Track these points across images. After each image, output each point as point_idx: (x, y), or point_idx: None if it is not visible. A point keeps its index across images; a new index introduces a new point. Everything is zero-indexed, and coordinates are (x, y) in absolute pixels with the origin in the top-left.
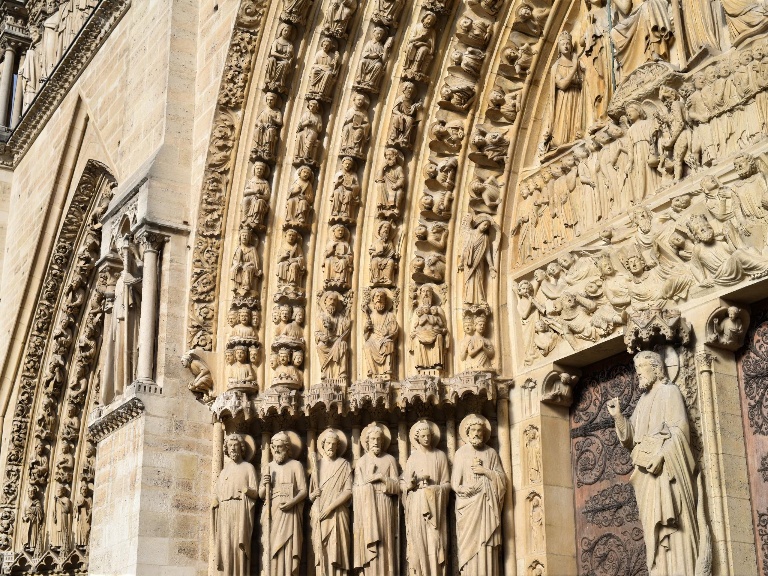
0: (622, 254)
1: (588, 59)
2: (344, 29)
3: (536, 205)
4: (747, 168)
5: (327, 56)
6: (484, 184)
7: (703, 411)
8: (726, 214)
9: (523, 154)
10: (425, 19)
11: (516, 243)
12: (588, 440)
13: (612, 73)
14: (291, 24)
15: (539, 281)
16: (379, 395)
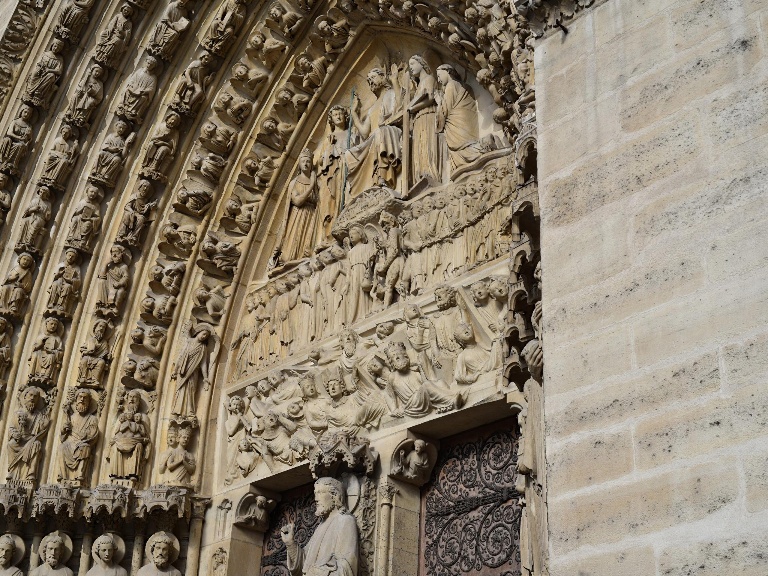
0: (325, 376)
1: (323, 178)
2: (86, 118)
3: (258, 320)
4: (446, 300)
5: (65, 143)
6: (209, 293)
7: (378, 546)
8: (423, 344)
9: (254, 267)
10: (169, 119)
11: (235, 357)
12: (277, 569)
13: (343, 194)
14: (33, 106)
15: (249, 398)
16: (64, 502)
